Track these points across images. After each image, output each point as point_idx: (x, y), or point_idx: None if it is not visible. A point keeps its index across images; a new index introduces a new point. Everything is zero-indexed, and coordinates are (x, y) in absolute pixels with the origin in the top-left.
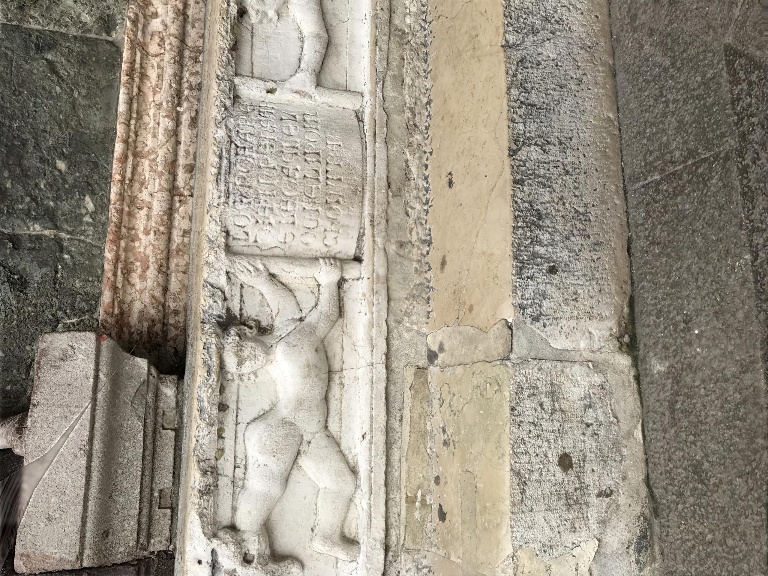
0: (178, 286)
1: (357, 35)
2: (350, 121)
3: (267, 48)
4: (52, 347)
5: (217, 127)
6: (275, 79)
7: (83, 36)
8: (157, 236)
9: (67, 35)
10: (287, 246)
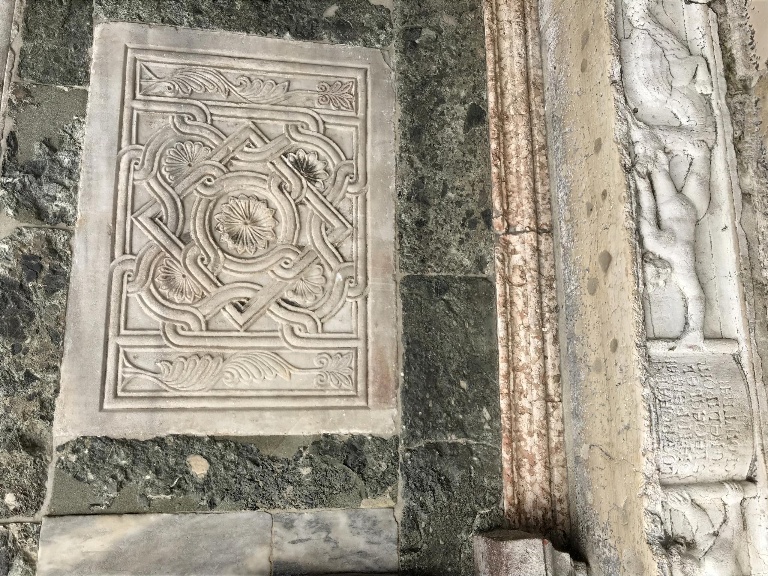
0: (560, 478)
1: (724, 290)
2: (731, 365)
3: (660, 311)
4: (514, 553)
5: (643, 387)
6: (670, 336)
7: (466, 276)
8: (541, 438)
9: (454, 277)
10: (698, 474)
